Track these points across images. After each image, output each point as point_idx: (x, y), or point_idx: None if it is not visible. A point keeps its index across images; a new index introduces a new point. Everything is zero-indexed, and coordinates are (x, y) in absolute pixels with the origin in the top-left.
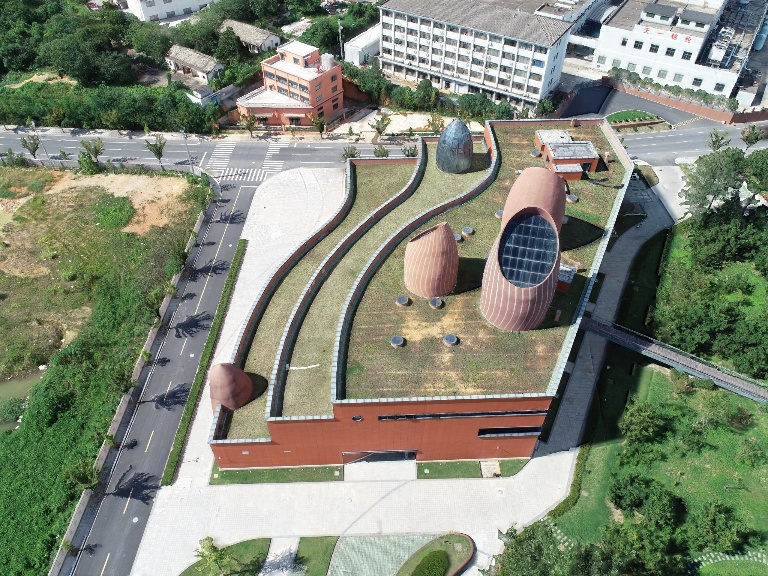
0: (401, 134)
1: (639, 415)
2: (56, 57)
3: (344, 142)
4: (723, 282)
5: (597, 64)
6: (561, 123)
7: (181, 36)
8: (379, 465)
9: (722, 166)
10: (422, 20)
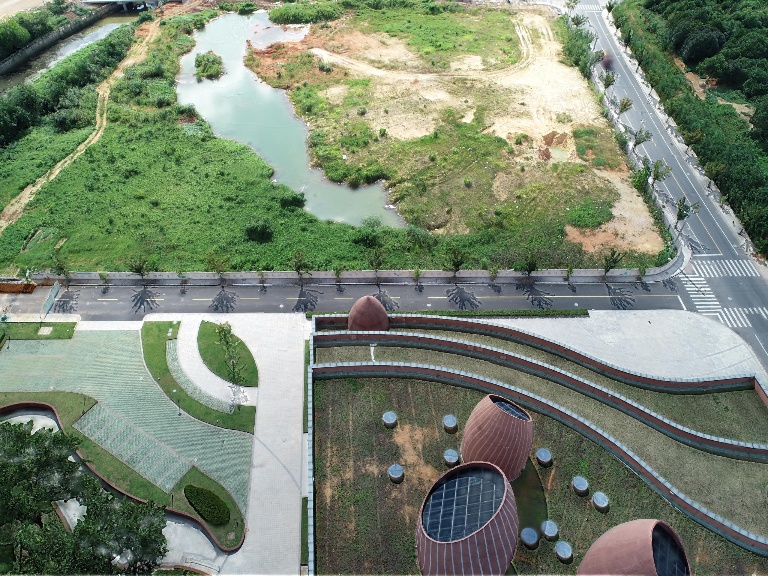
0: None
1: None
2: (764, 100)
3: None
4: None
5: None
6: None
7: None
8: None
9: None
10: None
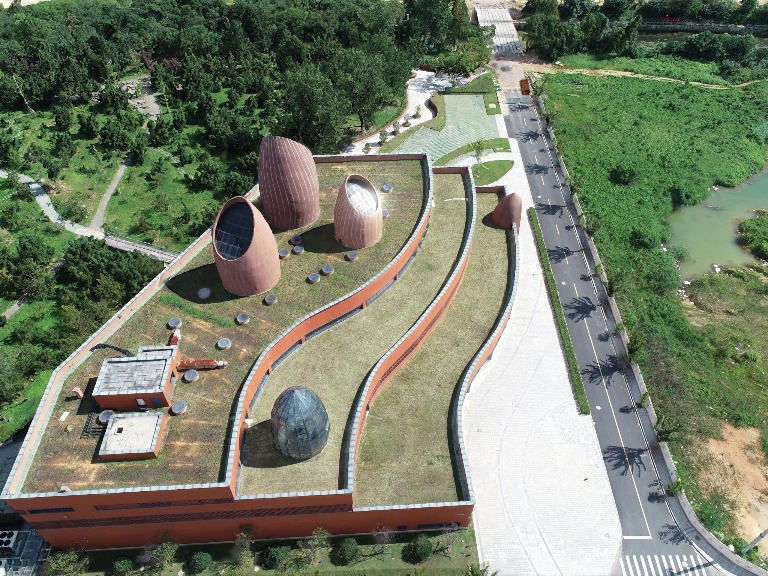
0: None
1: None
2: None
3: None
4: (37, 334)
5: None
6: None
7: None
8: None
9: None
10: None
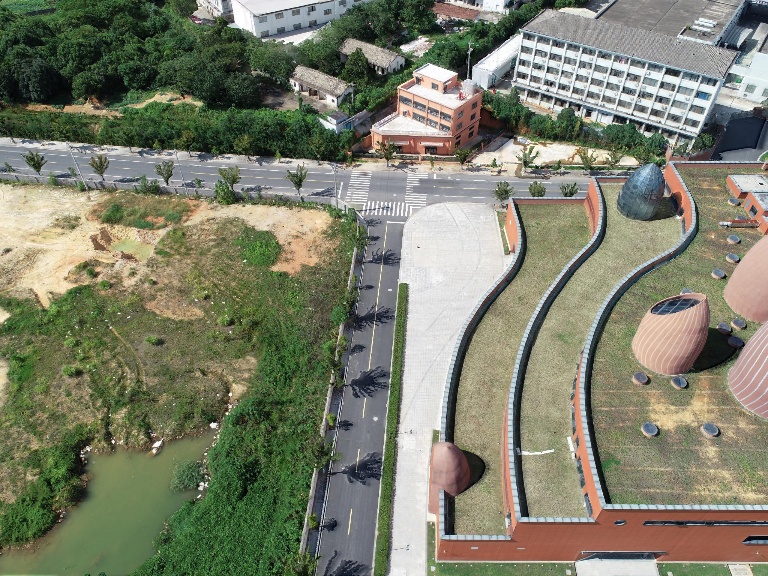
0: (545, 167)
1: None
2: (183, 77)
3: (486, 174)
4: None
5: (744, 93)
6: (751, 166)
7: (305, 56)
8: (614, 564)
9: None
10: (569, 45)
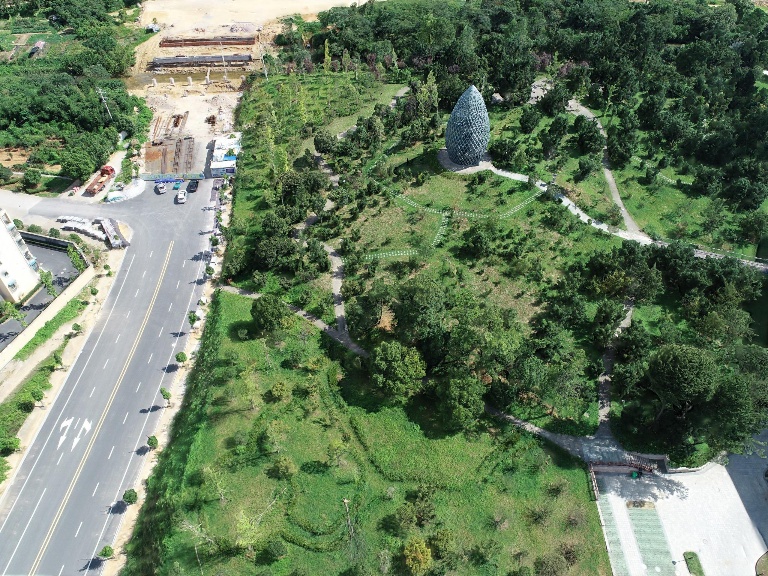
0: None
1: (765, 215)
2: None
3: None
4: None
5: None
6: None
7: None
8: None
9: (765, 349)
10: None
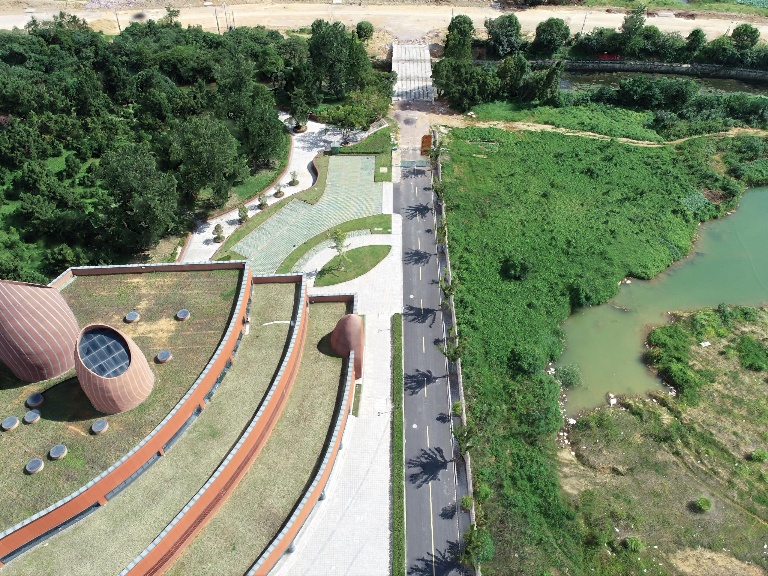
0: None
1: None
2: None
3: None
4: None
5: None
6: None
7: None
8: None
9: None
10: None
